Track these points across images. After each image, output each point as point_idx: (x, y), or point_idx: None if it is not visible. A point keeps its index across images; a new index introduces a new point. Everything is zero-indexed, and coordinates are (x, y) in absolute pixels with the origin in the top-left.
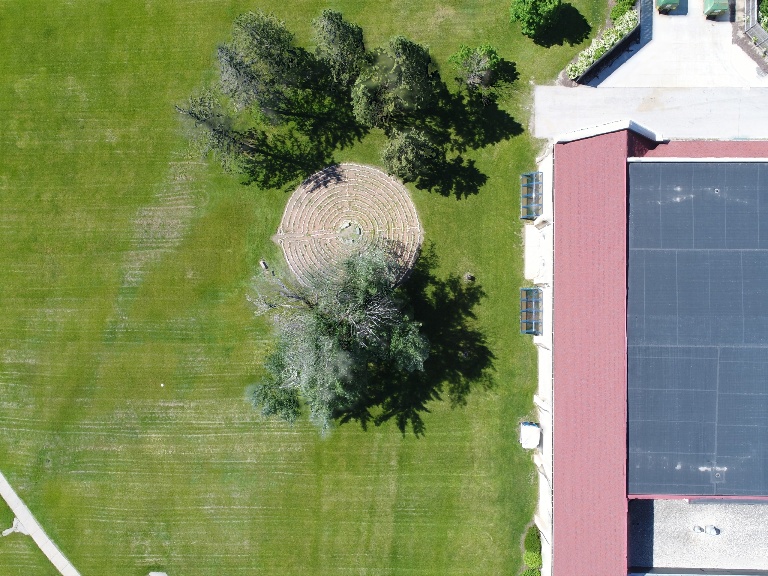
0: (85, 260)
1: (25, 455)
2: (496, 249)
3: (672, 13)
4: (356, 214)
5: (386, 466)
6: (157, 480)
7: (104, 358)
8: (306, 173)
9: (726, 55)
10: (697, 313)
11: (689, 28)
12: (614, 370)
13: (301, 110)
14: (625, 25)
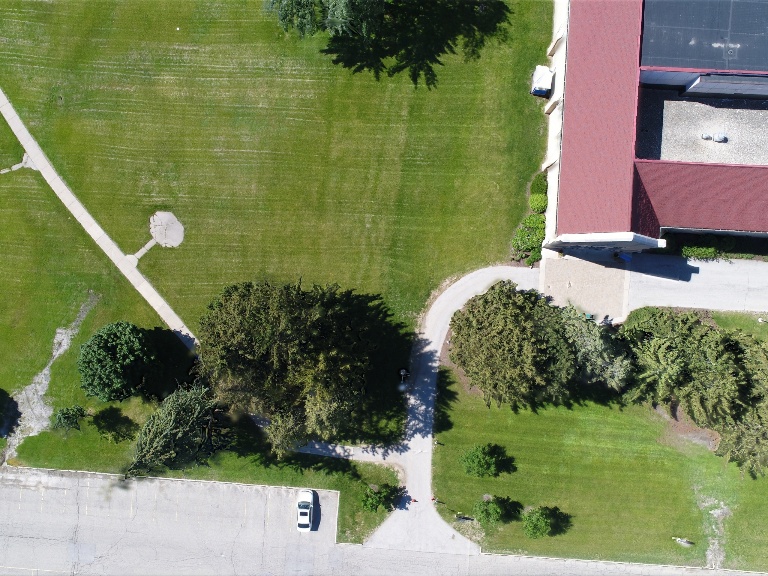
0: None
1: (38, 91)
2: None
3: None
4: None
5: (397, 116)
6: (168, 121)
7: None
8: None
9: None
10: None
11: None
12: None
13: None
14: None
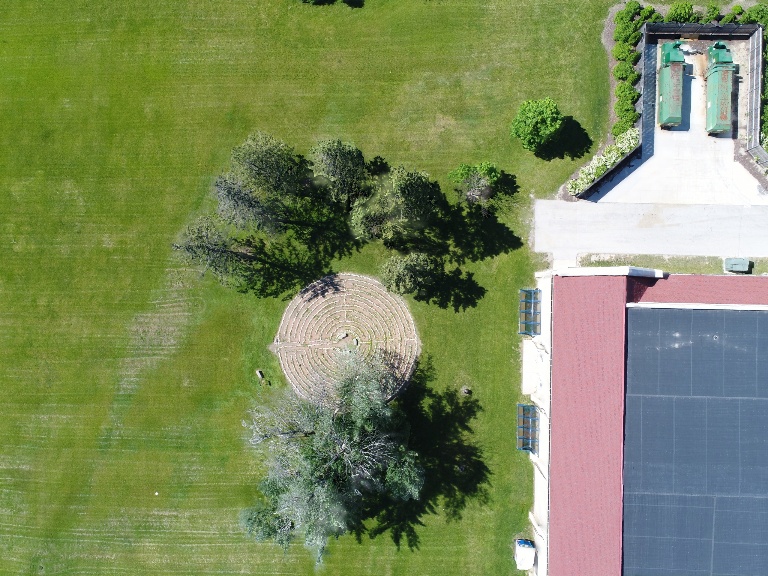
0: (80, 366)
1: (18, 562)
2: (494, 363)
3: (674, 129)
4: (353, 324)
5: None
6: None
7: (98, 465)
8: (304, 282)
9: (728, 172)
10: (694, 461)
11: (691, 144)
12: (610, 515)
13: (300, 218)
14: (626, 144)
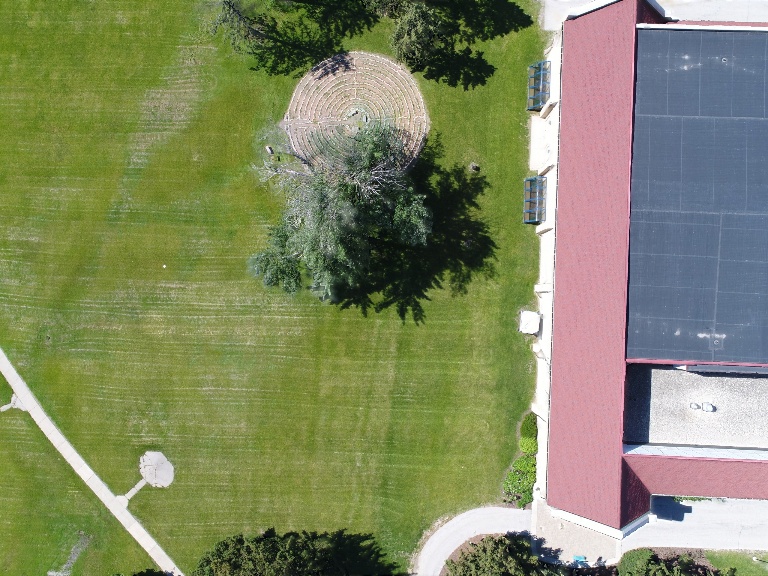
0: (92, 140)
1: (25, 332)
2: (502, 140)
3: None
4: (363, 102)
5: (385, 352)
6: (156, 360)
7: (107, 238)
8: (315, 60)
9: None
10: (701, 179)
11: None
12: (616, 236)
13: None
14: None
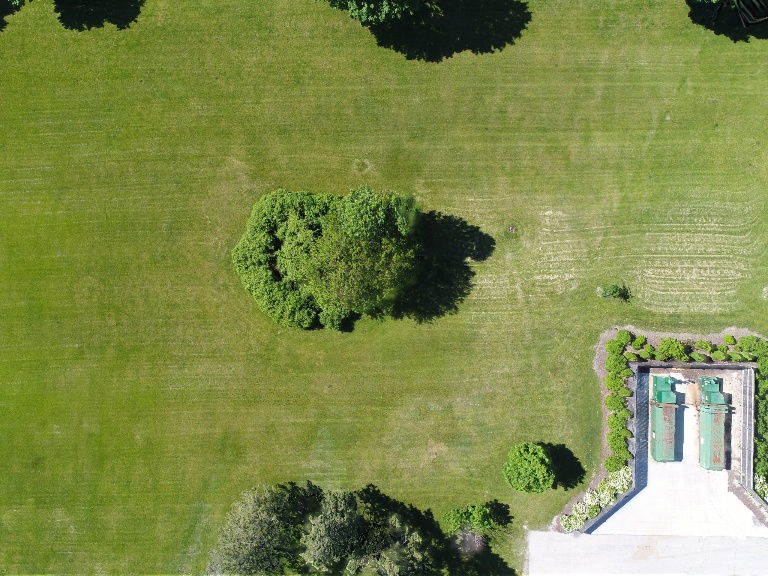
0: None
1: None
2: None
3: None
4: None
5: None
6: None
7: None
8: None
9: (722, 503)
10: None
11: (684, 475)
12: None
13: (292, 546)
14: (620, 485)
